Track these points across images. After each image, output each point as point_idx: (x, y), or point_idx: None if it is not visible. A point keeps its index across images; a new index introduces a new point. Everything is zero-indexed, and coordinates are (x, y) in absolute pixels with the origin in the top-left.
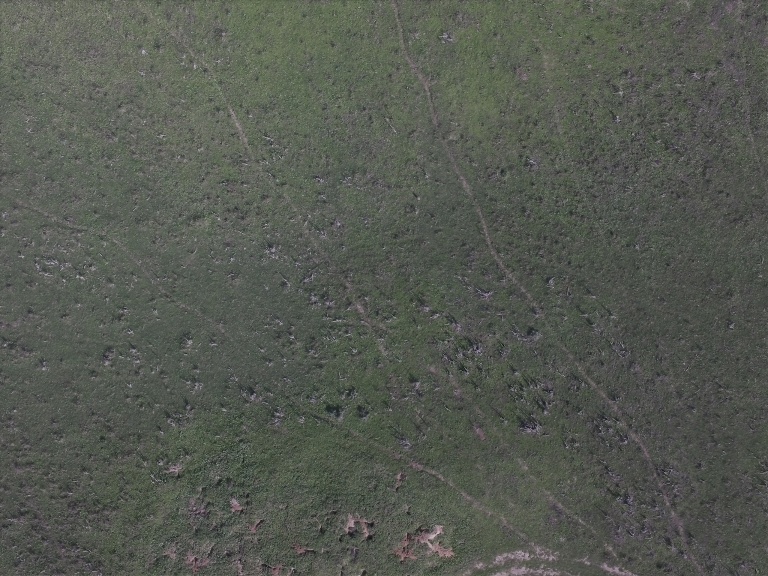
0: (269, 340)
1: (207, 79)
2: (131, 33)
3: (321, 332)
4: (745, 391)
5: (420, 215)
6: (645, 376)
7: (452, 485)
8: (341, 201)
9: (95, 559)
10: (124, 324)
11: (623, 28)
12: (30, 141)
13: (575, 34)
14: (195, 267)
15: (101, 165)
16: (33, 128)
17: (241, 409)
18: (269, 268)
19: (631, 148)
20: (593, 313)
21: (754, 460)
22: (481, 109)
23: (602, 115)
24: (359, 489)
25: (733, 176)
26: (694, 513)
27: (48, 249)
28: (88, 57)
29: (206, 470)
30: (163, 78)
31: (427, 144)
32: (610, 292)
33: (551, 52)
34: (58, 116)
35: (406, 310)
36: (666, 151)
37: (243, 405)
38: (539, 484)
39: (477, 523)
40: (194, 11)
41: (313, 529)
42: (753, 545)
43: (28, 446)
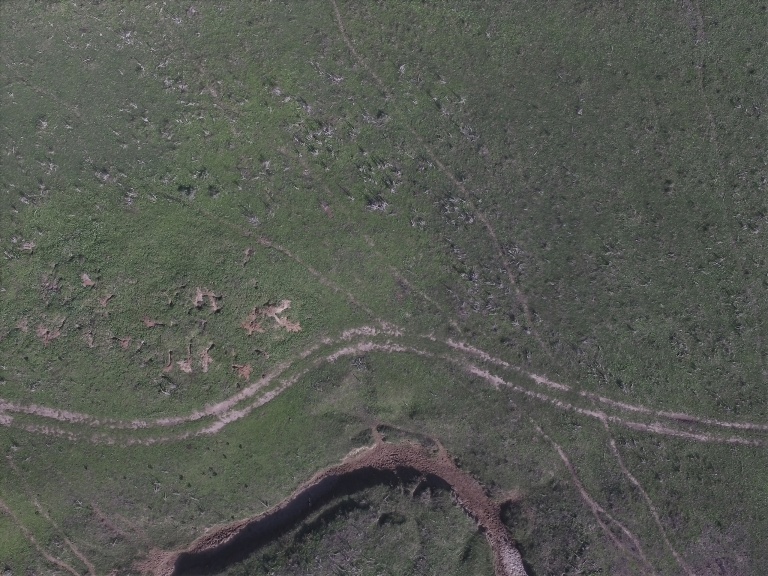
0: (124, 124)
1: None
2: None
3: (175, 116)
4: (592, 175)
5: (275, 4)
6: (493, 160)
7: (300, 261)
8: None
9: None
10: None
11: None
12: None
13: None
14: (51, 53)
15: None
16: None
17: (95, 190)
18: (125, 54)
19: None
20: (443, 98)
21: (599, 241)
22: None
23: None
24: (208, 264)
25: None
26: (538, 291)
27: None
28: None
29: (59, 247)
30: None
31: None
32: (461, 79)
33: None
34: None
35: (258, 94)
36: None
37: (97, 186)
38: (385, 260)
39: (324, 299)
40: None
41: (163, 303)
42: (596, 323)
43: None
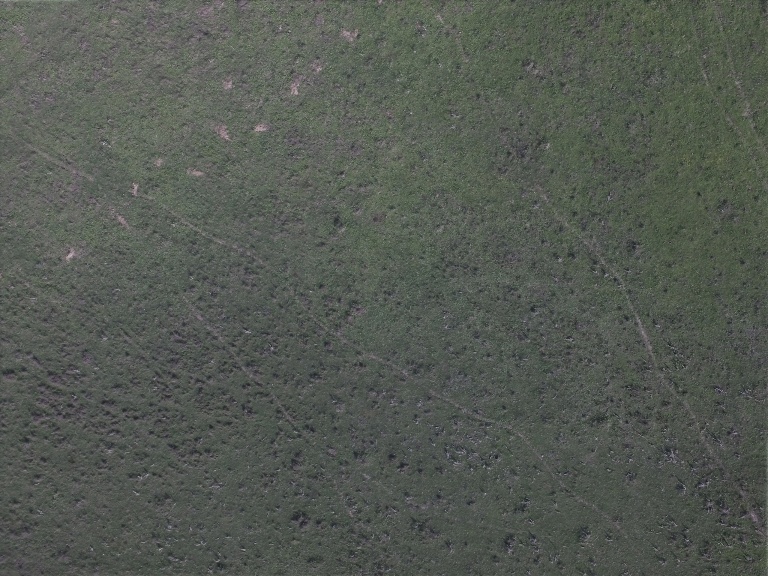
0: (663, 540)
1: (616, 287)
2: (547, 240)
3: (714, 537)
4: None
5: None
6: None
7: None
8: (739, 412)
9: None
10: (526, 514)
11: None
12: (446, 336)
13: None
14: (594, 464)
15: (511, 363)
16: (449, 324)
17: None
18: (665, 471)
19: None
20: None
21: None
22: None
23: None
24: None
25: None
26: None
27: (457, 438)
28: (505, 260)
29: None
30: (575, 284)
31: None
32: None
33: None
34: (474, 314)
35: None
36: None
37: None
38: None
39: None
40: (609, 222)
41: None
42: None
43: None
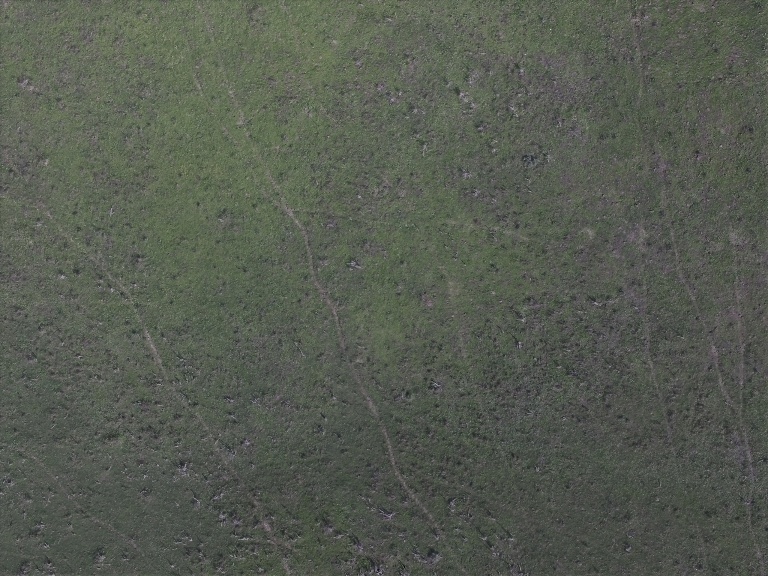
0: (179, 556)
1: (124, 301)
2: (52, 257)
3: (229, 549)
4: None
5: (327, 434)
6: None
7: None
8: (251, 421)
9: None
10: (40, 538)
11: (526, 256)
12: None
13: (479, 261)
14: (110, 483)
15: (21, 384)
16: None
17: None
18: (181, 485)
19: (533, 372)
20: (493, 535)
21: None
22: (387, 333)
23: (505, 340)
24: None
25: (632, 402)
26: None
27: None
28: (10, 280)
29: None
30: (82, 300)
31: (335, 366)
32: (510, 514)
33: (456, 278)
34: None
35: (311, 530)
36: (567, 376)
37: None
38: None
39: None
40: (112, 236)
41: None
42: None
43: None
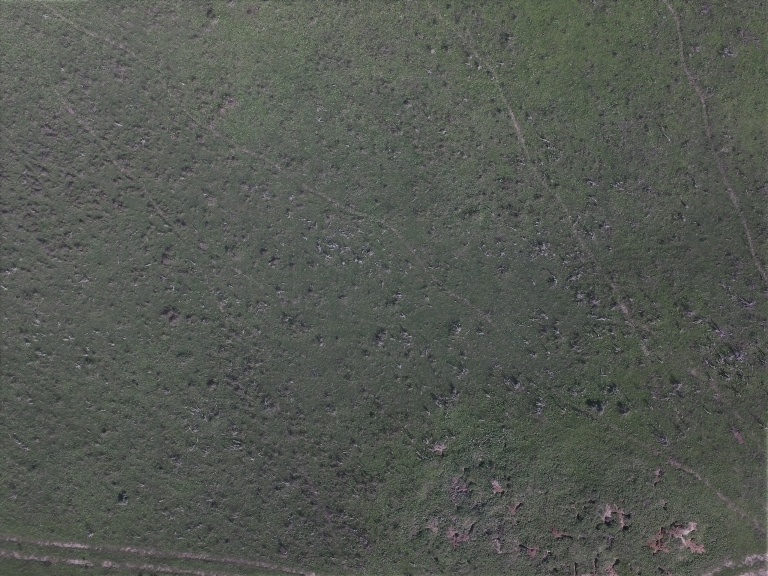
0: (534, 333)
1: (489, 80)
2: (421, 32)
3: (585, 329)
4: None
5: (686, 223)
6: None
7: (708, 485)
8: (611, 204)
9: (361, 526)
10: (397, 308)
11: None
12: (319, 130)
13: None
14: (466, 259)
15: (384, 156)
16: (322, 117)
17: (504, 396)
18: (537, 264)
19: None
20: None
21: None
22: (755, 123)
23: None
24: (618, 481)
25: None
26: None
27: (330, 232)
28: (379, 53)
29: (470, 452)
30: (448, 77)
31: (699, 154)
32: None
33: None
34: (347, 107)
35: (670, 314)
36: None
37: (506, 393)
38: None
39: (730, 523)
40: (482, 14)
41: (571, 516)
42: None
43: (303, 416)
